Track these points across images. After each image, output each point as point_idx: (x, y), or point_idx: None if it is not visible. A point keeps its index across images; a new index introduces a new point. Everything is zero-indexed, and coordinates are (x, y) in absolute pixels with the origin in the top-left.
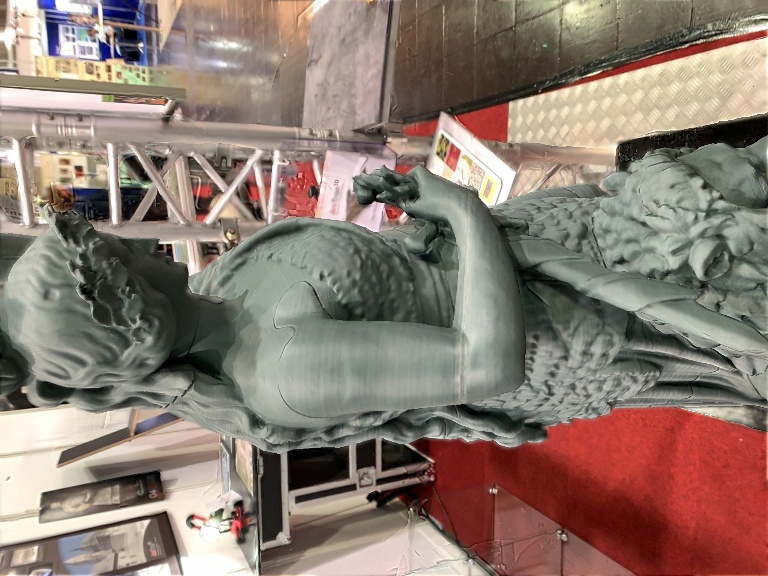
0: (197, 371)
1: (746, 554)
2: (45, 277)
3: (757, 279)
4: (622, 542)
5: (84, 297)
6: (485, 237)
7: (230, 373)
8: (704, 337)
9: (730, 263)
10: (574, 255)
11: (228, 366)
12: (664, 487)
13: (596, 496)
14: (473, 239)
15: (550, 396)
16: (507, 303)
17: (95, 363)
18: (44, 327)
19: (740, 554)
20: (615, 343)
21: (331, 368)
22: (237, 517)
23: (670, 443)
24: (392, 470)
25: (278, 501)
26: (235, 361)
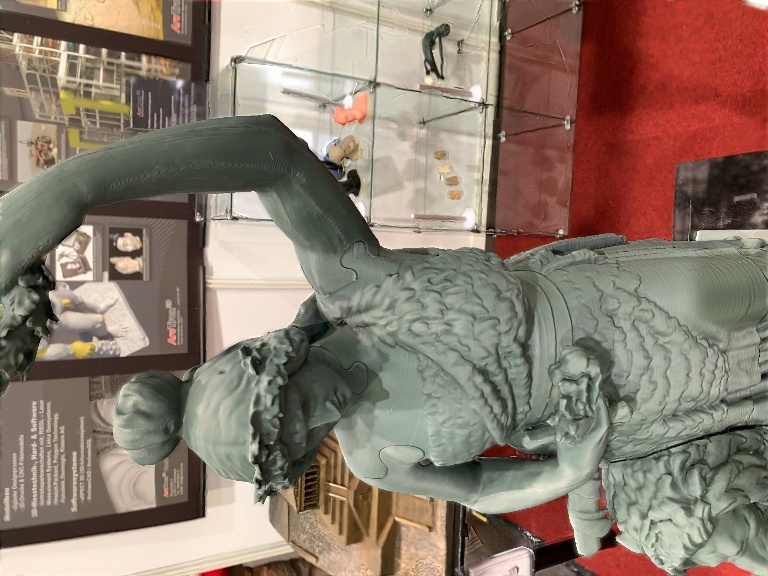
0: None
1: (632, 185)
2: None
3: None
4: (597, 73)
5: None
6: None
7: None
8: None
9: None
10: (593, 495)
11: None
12: (659, 101)
13: (626, 29)
14: (546, 494)
15: None
16: None
17: None
18: None
19: (630, 180)
20: None
21: None
22: None
23: (703, 95)
24: None
25: None
26: (341, 430)
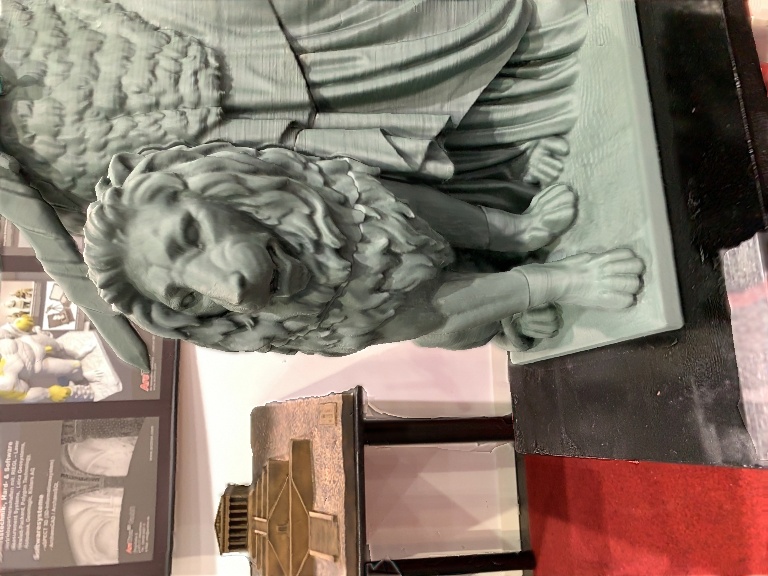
0: None
1: None
2: None
3: None
4: None
5: None
6: None
7: None
8: None
9: None
10: (40, 227)
11: None
12: None
13: None
14: None
15: None
16: None
17: None
18: None
19: None
20: None
21: None
22: None
23: None
24: None
25: None
26: None
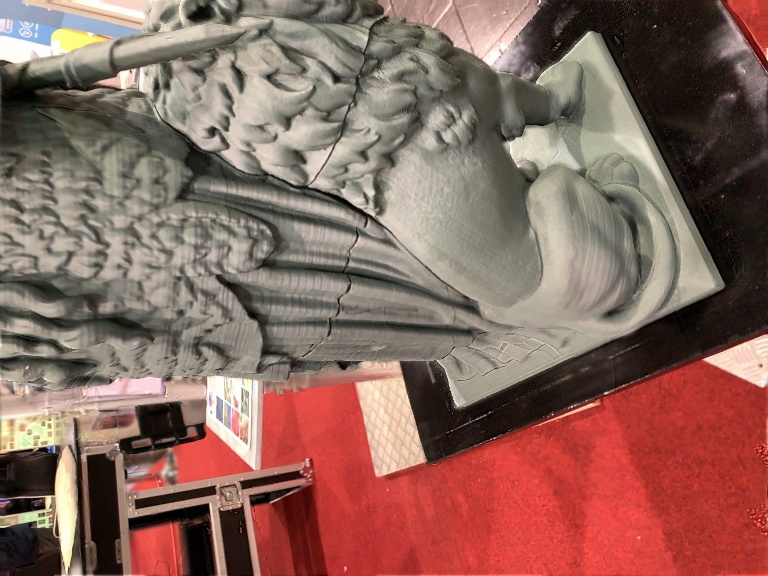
0: None
1: None
2: None
3: (256, 24)
4: None
5: None
6: None
7: None
8: (171, 43)
9: (224, 17)
10: None
11: None
12: None
13: None
14: None
15: (104, 247)
16: None
17: None
18: None
19: None
20: (169, 168)
21: None
22: None
23: None
24: None
25: None
26: None
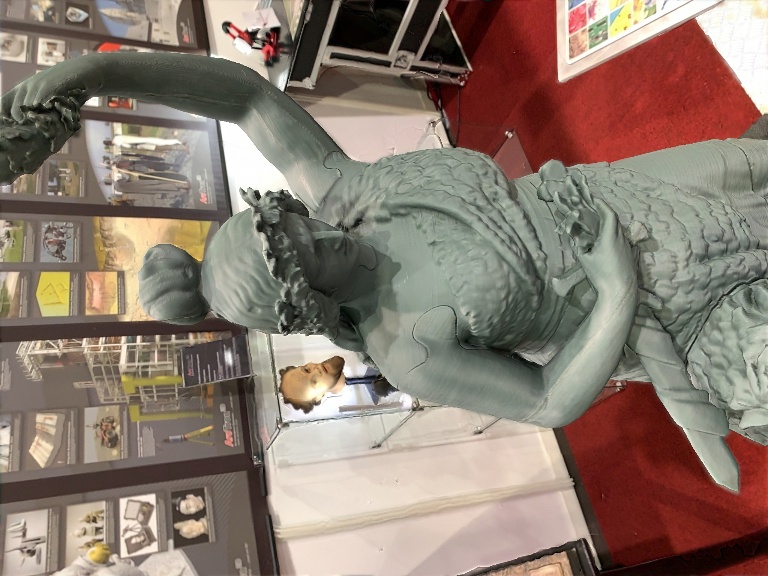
0: (339, 326)
1: None
2: (252, 299)
3: None
4: None
5: (283, 332)
6: (614, 339)
7: (364, 335)
8: None
9: None
10: (673, 359)
11: (364, 330)
12: None
13: None
14: (604, 335)
15: None
16: (592, 395)
17: (270, 331)
18: (242, 321)
19: None
20: None
21: (441, 394)
22: (271, 42)
23: None
24: (430, 61)
25: (315, 50)
26: (371, 333)
